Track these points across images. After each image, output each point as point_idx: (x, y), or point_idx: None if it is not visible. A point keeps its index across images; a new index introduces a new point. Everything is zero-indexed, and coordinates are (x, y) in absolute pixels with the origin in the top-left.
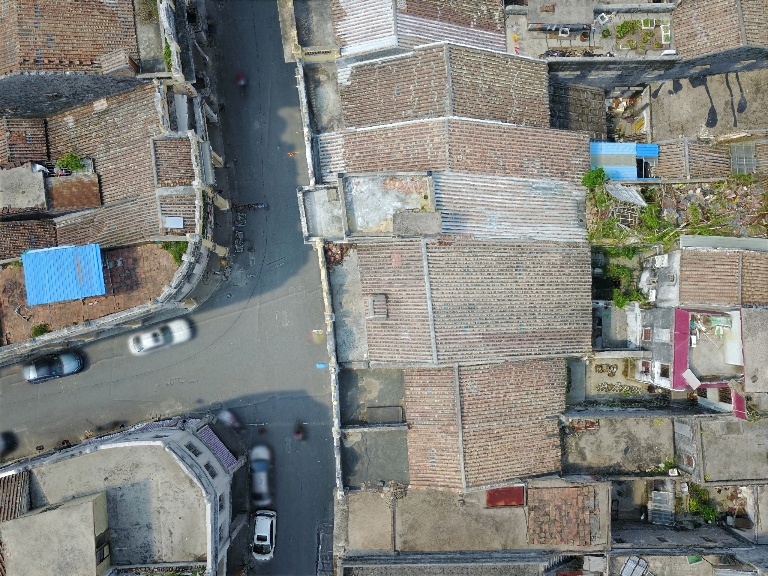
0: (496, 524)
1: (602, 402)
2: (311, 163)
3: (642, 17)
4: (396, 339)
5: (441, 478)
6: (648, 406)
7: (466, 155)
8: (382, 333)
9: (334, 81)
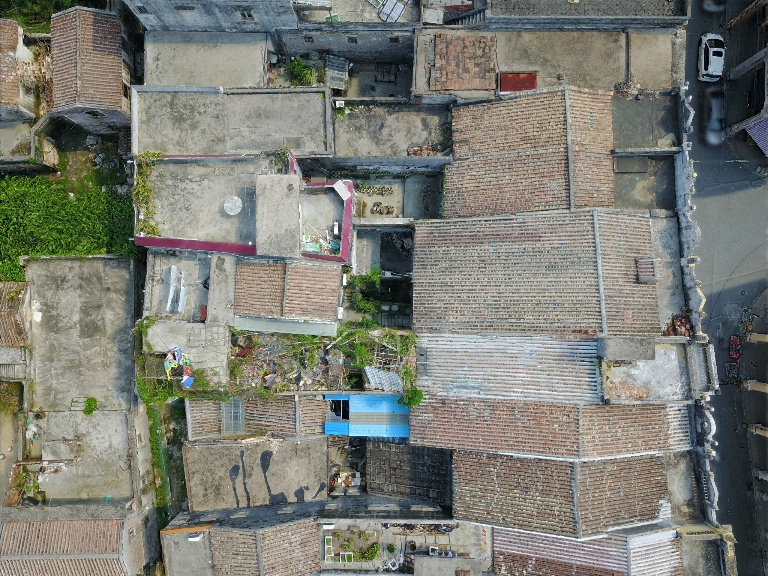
0: (527, 56)
1: (387, 177)
2: (710, 418)
3: (351, 565)
4: (628, 238)
5: (585, 101)
6: (349, 171)
7: (558, 422)
8: (639, 244)
9: (673, 505)
